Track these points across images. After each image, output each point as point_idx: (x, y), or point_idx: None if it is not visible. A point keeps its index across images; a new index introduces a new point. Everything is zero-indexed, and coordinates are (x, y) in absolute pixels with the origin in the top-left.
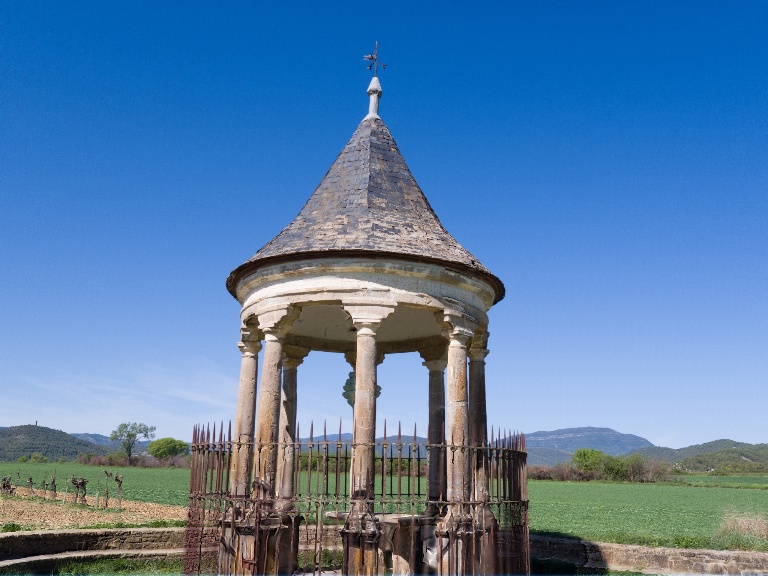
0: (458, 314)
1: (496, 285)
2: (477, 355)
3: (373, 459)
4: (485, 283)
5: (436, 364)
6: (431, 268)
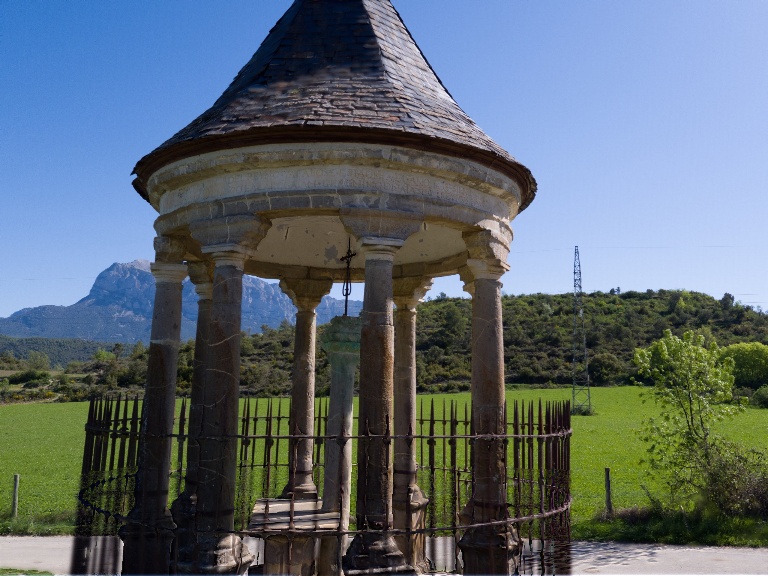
0: None
1: None
2: None
3: None
4: None
5: None
6: None
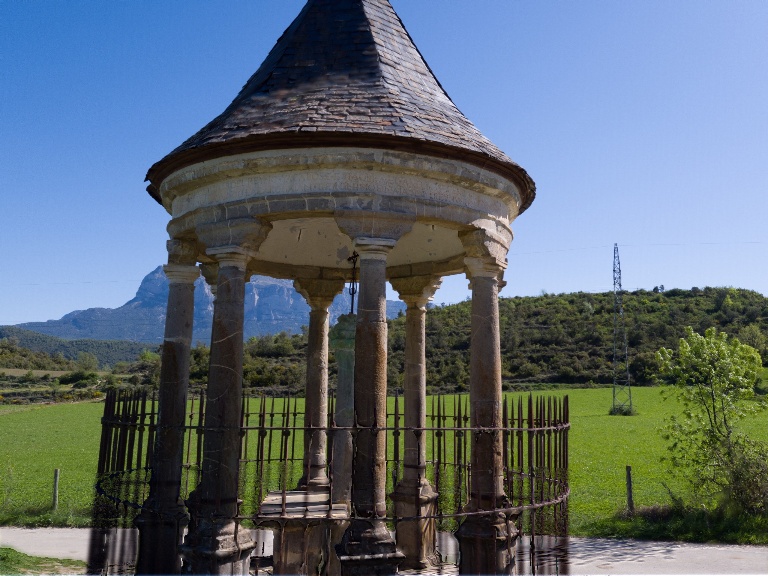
0: None
1: None
2: None
3: None
4: None
5: None
6: None
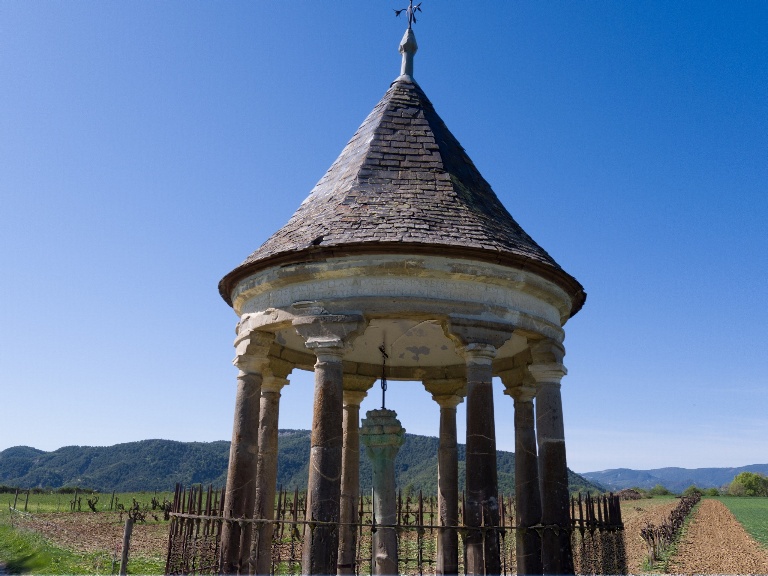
0: (307, 321)
1: (409, 246)
2: (465, 357)
3: (233, 532)
4: (367, 256)
5: (532, 372)
6: (267, 274)
